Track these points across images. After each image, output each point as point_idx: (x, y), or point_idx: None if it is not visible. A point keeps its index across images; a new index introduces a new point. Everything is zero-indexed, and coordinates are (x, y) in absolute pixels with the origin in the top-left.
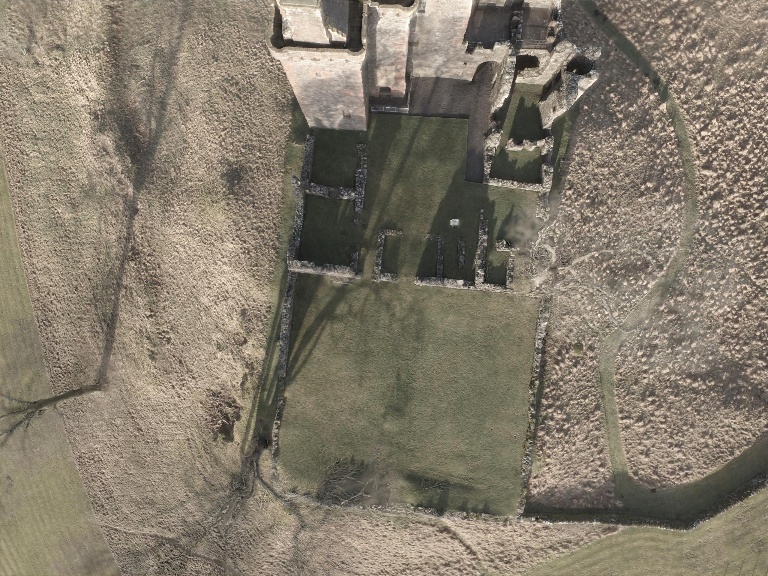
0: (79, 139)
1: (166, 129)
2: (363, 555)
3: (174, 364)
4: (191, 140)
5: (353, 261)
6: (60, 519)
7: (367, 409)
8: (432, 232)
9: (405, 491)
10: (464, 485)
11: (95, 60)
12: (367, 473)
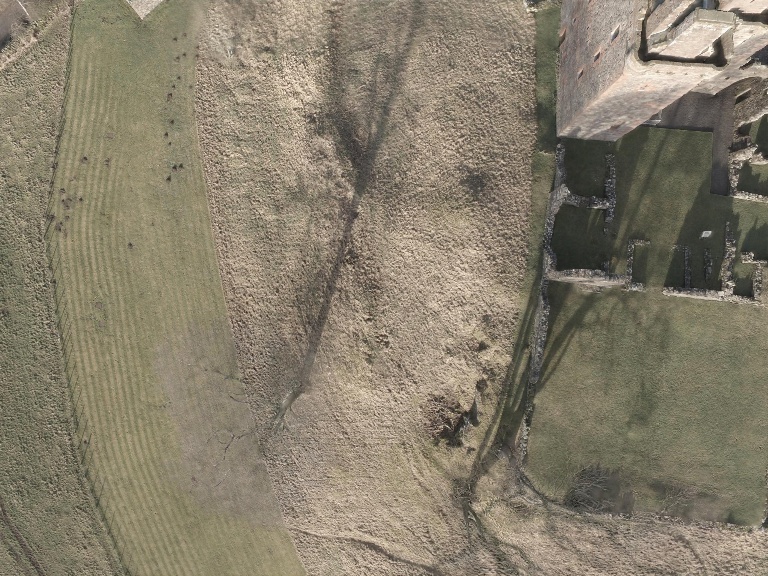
0: (288, 141)
1: (389, 134)
2: (592, 563)
3: (392, 368)
4: (421, 146)
5: (605, 270)
6: (246, 521)
7: (612, 417)
8: (679, 243)
9: (650, 500)
10: (708, 495)
11: (315, 64)
12: (613, 481)
